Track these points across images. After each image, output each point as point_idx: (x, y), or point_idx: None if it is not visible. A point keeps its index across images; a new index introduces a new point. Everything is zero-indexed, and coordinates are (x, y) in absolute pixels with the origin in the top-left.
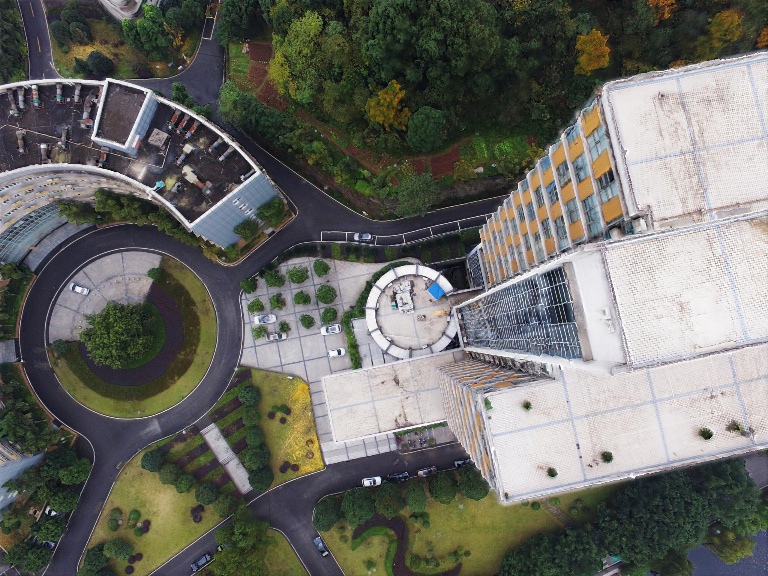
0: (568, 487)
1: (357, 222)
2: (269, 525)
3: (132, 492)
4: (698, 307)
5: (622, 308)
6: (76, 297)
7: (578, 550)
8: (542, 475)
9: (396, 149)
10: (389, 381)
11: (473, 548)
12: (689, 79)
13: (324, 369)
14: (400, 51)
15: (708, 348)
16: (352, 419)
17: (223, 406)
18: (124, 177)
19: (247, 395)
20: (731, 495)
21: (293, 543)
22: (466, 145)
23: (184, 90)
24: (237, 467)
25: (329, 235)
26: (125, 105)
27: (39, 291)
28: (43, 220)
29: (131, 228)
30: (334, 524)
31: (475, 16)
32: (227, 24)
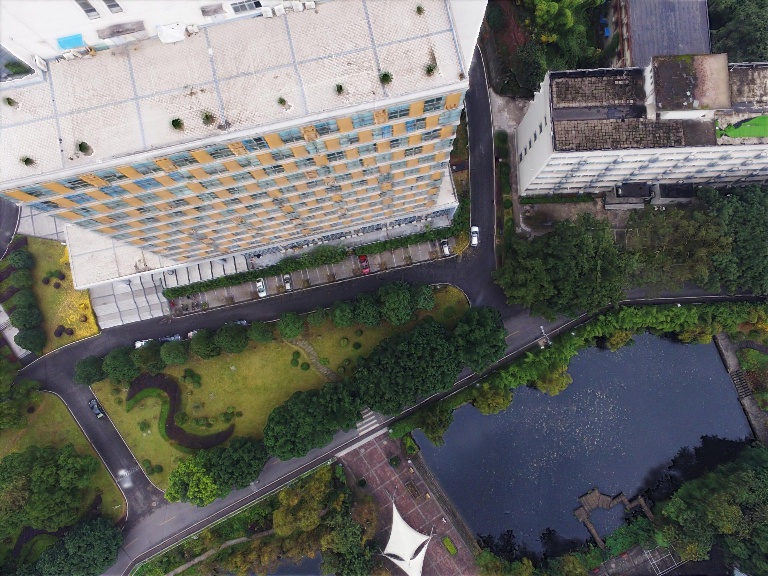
0: None
1: None
2: (39, 384)
3: None
4: None
5: None
6: None
7: (333, 400)
8: (23, 167)
9: None
10: None
11: (245, 409)
12: None
13: None
14: None
15: None
16: (93, 265)
17: None
18: None
19: (15, 257)
20: (477, 340)
21: (70, 406)
22: None
23: None
24: (9, 329)
25: None
26: None
27: None
28: None
29: None
30: None
31: None
32: None
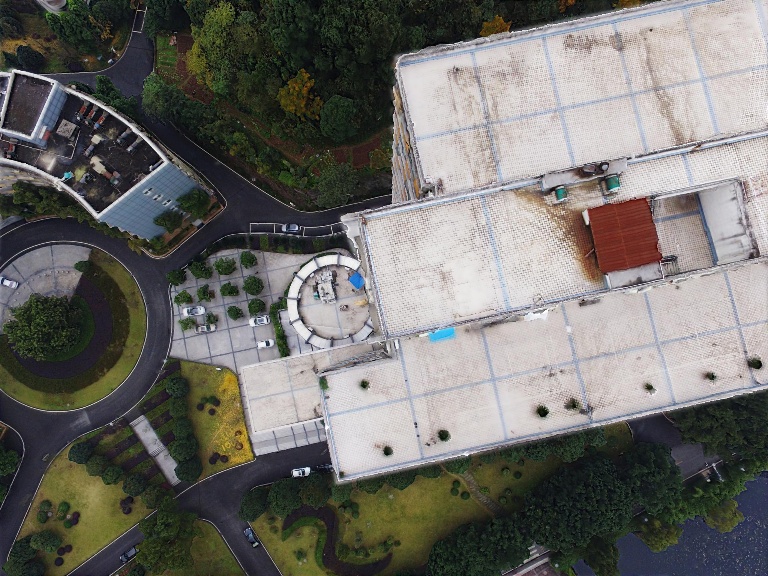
0: (403, 465)
1: (285, 213)
2: (197, 516)
3: (61, 484)
4: (460, 276)
5: (383, 278)
6: (5, 290)
7: (503, 539)
8: (379, 454)
9: (317, 139)
10: (308, 371)
11: (403, 538)
12: (484, 52)
13: (253, 360)
14: (306, 40)
15: (467, 317)
16: (271, 409)
17: (152, 398)
18: (32, 168)
19: (174, 387)
20: (654, 483)
21: (224, 534)
22: (387, 135)
23: (109, 83)
24: (165, 458)
25: (257, 227)
26: (32, 96)
27: None
28: None
29: (60, 221)
30: (262, 515)
31: (375, 3)
32: (151, 16)
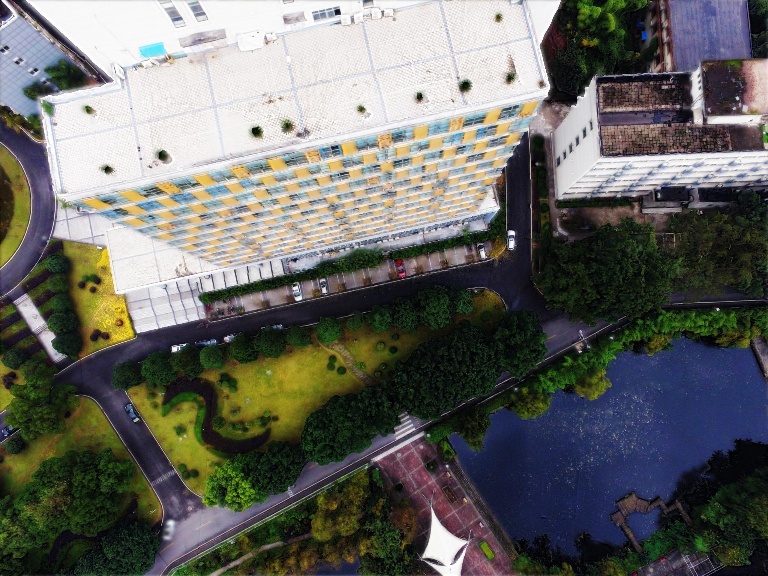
0: None
1: None
2: (76, 389)
3: None
4: None
5: None
6: None
7: (372, 405)
8: (102, 175)
9: None
10: None
11: (281, 413)
12: None
13: None
14: None
15: None
16: (133, 269)
17: None
18: None
19: (52, 261)
20: (517, 345)
21: (106, 411)
22: None
23: None
24: (45, 333)
25: None
26: None
27: None
28: None
29: None
30: None
31: None
32: None
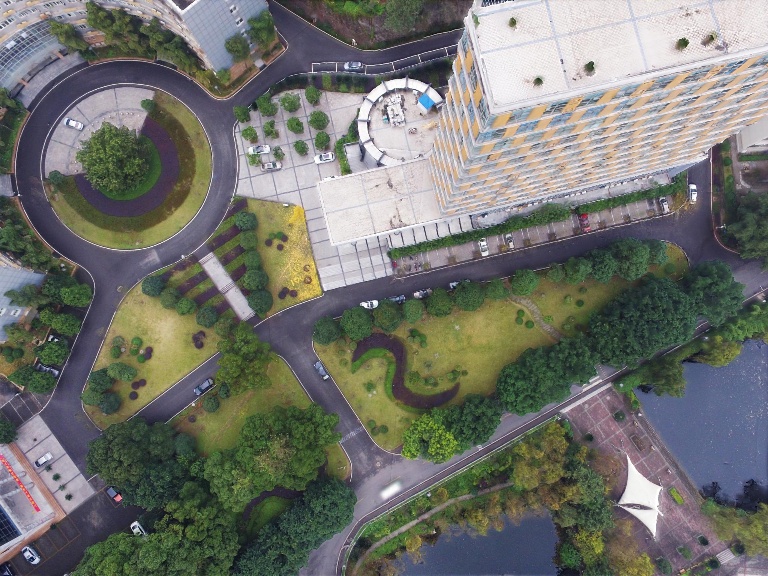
0: None
1: (347, 53)
2: (270, 346)
3: (133, 320)
4: None
5: None
6: (71, 133)
7: (572, 355)
8: (528, 87)
9: None
10: (383, 184)
11: (470, 368)
12: None
13: None
14: None
15: None
16: (348, 221)
17: (220, 234)
18: None
19: (244, 218)
20: (717, 293)
21: (294, 369)
22: None
23: None
24: (236, 291)
25: (320, 66)
26: None
27: (33, 128)
28: (35, 48)
29: (123, 65)
30: None
31: None
32: None
